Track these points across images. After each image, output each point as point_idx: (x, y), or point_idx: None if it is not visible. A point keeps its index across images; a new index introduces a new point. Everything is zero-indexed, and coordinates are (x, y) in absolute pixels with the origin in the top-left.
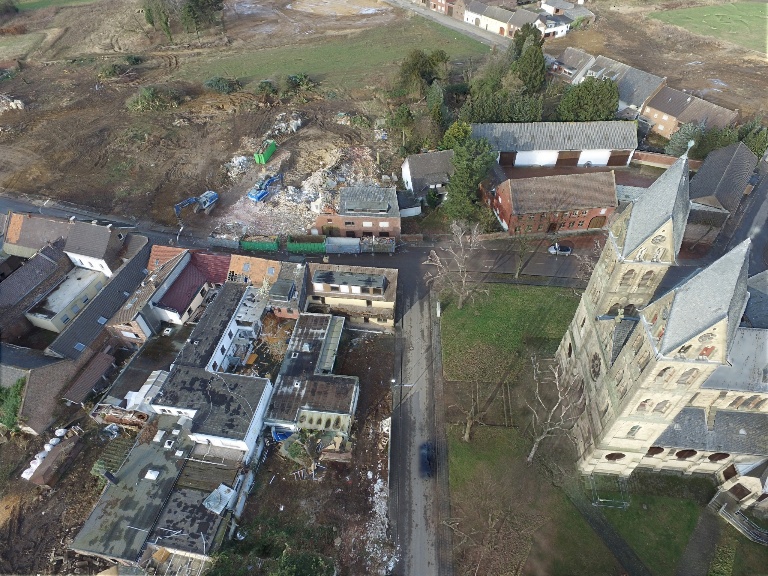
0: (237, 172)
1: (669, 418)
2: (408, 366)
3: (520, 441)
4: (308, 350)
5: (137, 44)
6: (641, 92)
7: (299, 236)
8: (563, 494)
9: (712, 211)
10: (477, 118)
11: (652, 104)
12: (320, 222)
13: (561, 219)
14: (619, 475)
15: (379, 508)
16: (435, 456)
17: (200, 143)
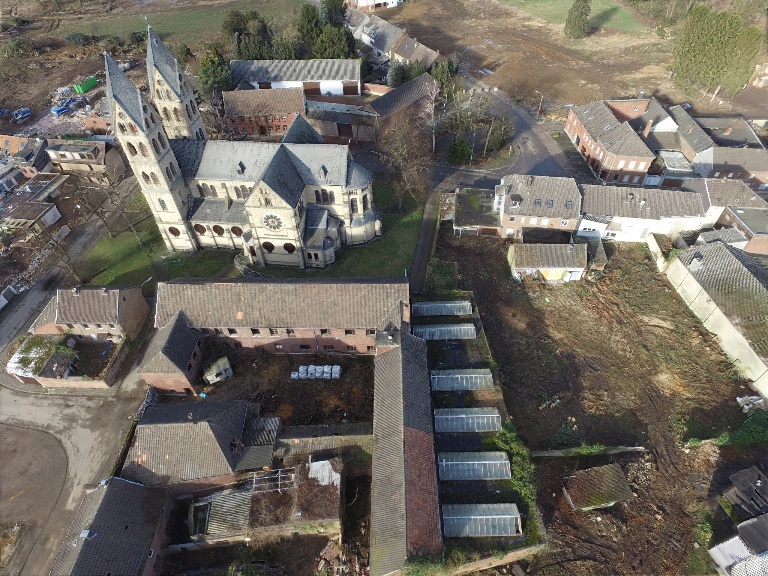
0: (58, 98)
1: (167, 189)
2: (104, 205)
3: (144, 237)
4: (30, 190)
5: (32, 10)
6: (390, 42)
7: (74, 134)
8: (150, 259)
9: (367, 115)
10: (245, 57)
11: (397, 51)
12: (89, 124)
13: (266, 123)
14: (189, 249)
15: (31, 266)
16: (87, 246)
17: (41, 80)
